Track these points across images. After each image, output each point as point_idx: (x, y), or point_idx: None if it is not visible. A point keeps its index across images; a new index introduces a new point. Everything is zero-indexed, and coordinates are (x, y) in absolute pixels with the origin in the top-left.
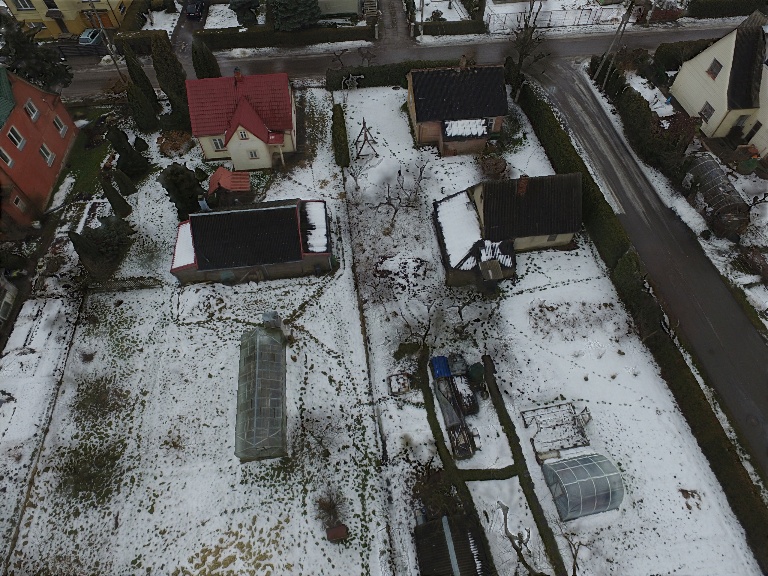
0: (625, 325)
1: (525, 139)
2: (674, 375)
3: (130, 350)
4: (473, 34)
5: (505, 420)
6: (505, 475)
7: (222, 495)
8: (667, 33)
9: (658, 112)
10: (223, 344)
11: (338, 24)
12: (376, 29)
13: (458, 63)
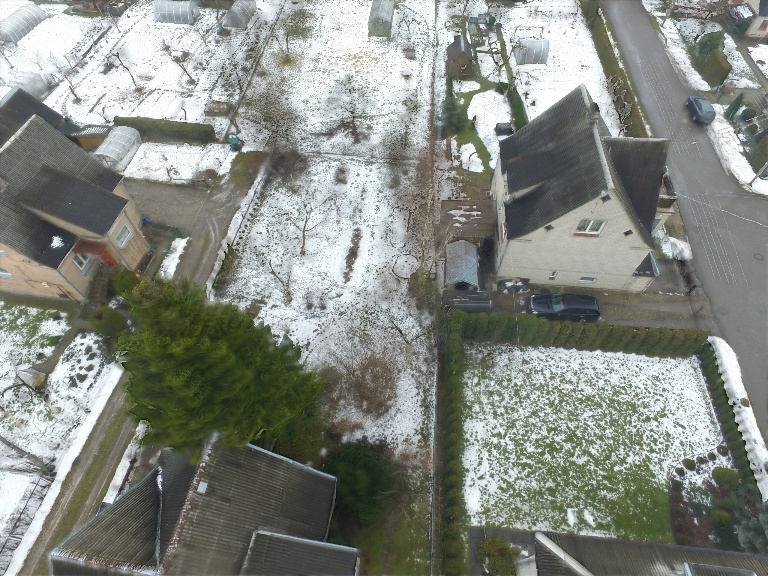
0: (580, 21)
1: None
2: (596, 32)
3: (316, 3)
4: None
5: (501, 40)
6: (495, 53)
7: (359, 43)
8: None
9: None
10: (362, 6)
11: None
12: None
13: None
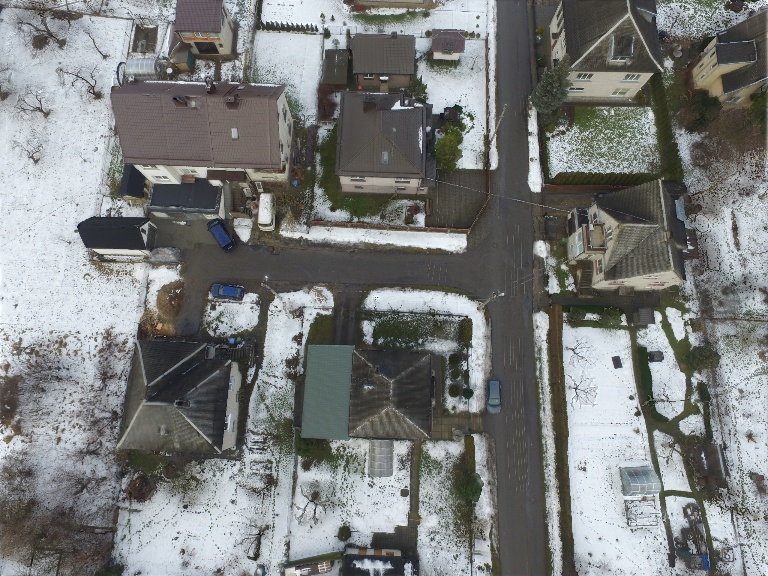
0: (580, 575)
1: None
2: None
3: None
4: None
5: (667, 522)
6: (671, 492)
7: None
8: None
9: None
10: None
11: None
12: None
13: None
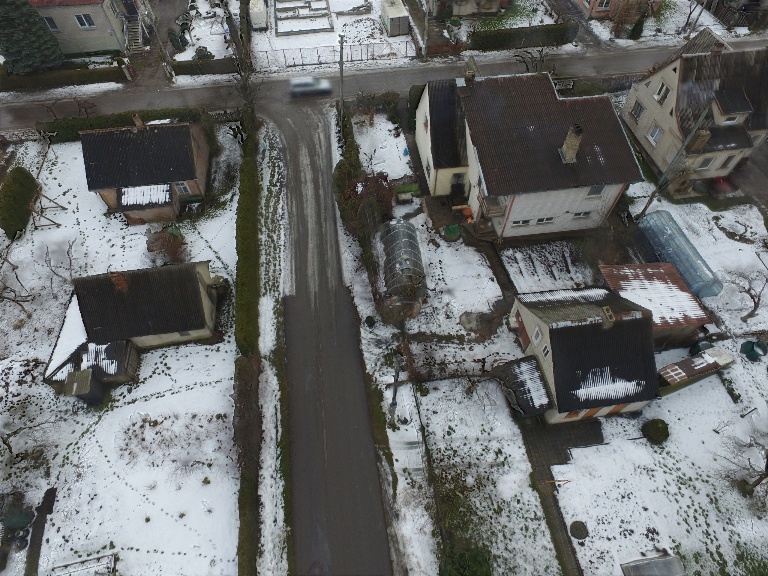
0: (230, 443)
1: (230, 202)
2: None
3: None
4: (236, 73)
5: None
6: None
7: None
8: (443, 69)
9: (391, 165)
10: None
11: (96, 63)
12: (124, 70)
13: (186, 112)
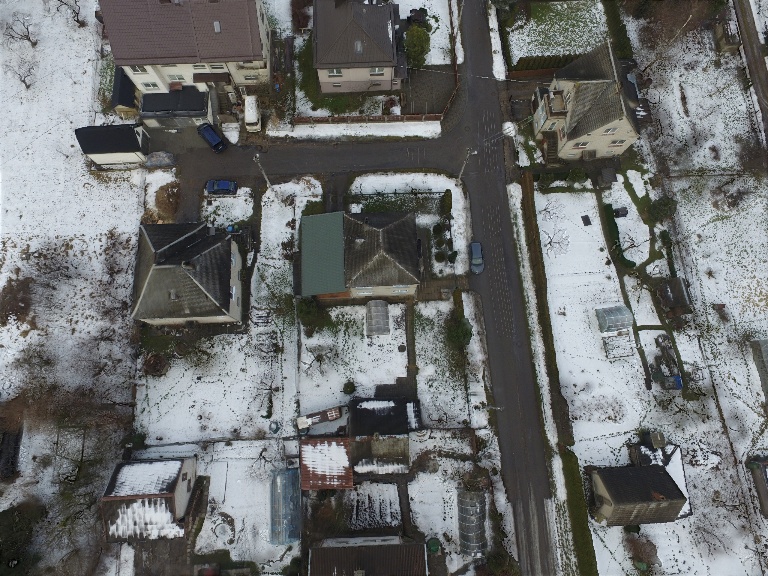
0: None
1: None
2: None
3: None
4: None
5: (641, 352)
6: (643, 327)
7: None
8: None
9: None
10: None
11: None
12: None
13: None
